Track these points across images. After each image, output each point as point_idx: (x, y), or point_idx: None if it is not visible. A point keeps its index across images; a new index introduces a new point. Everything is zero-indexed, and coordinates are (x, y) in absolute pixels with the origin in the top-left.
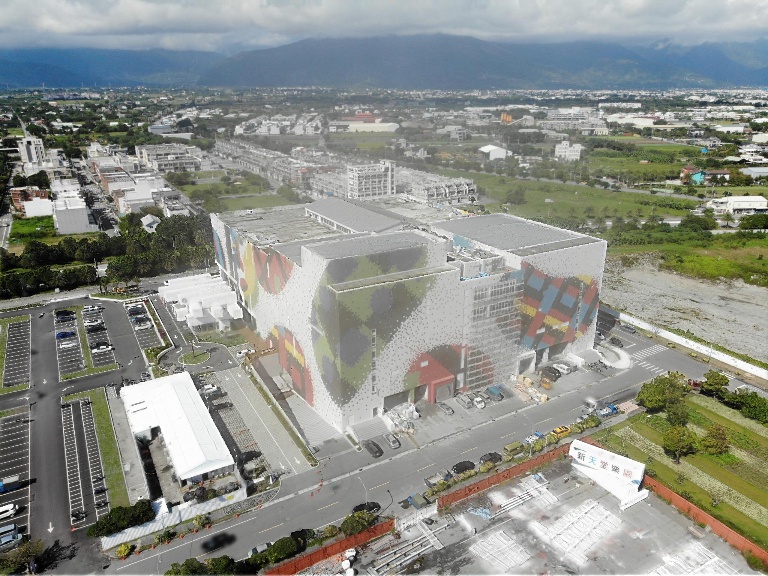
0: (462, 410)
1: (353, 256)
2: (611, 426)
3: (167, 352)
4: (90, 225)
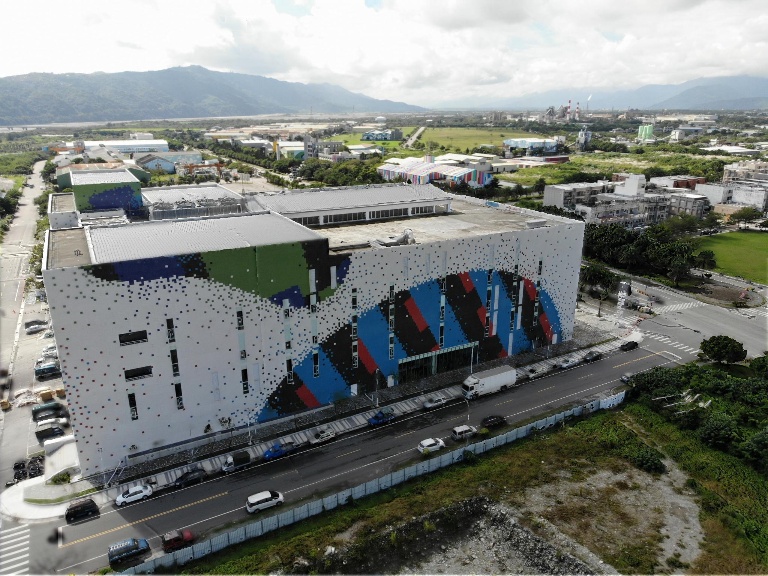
0: None
1: (71, 174)
2: None
3: None
4: (564, 207)
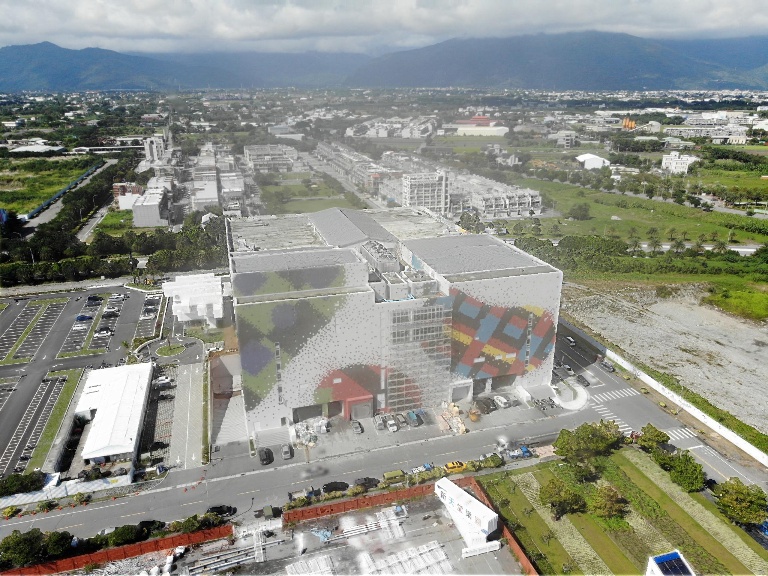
0: (373, 431)
1: None
2: (513, 469)
3: (152, 342)
4: (161, 220)
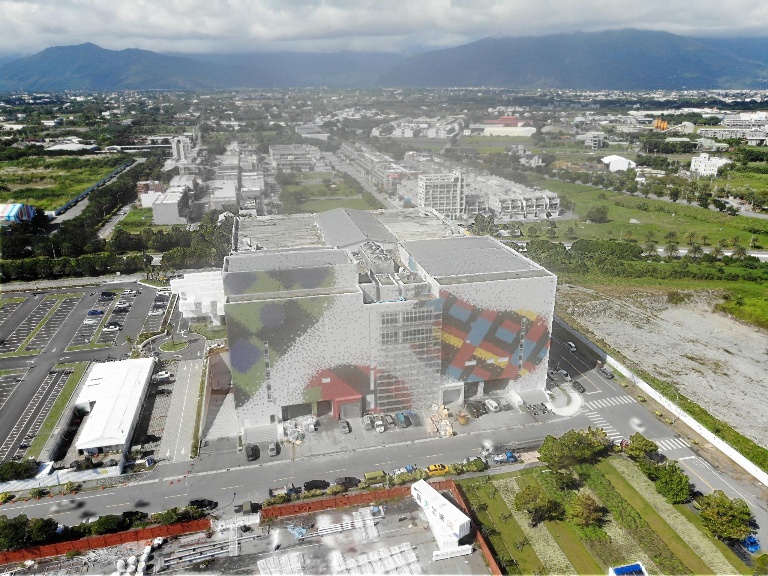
0: (360, 431)
1: (252, 271)
2: (496, 474)
3: (158, 338)
4: (180, 218)
